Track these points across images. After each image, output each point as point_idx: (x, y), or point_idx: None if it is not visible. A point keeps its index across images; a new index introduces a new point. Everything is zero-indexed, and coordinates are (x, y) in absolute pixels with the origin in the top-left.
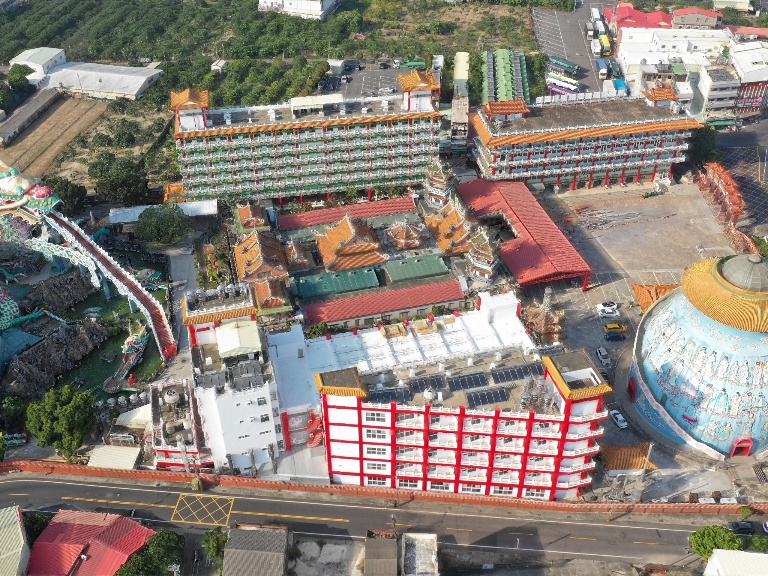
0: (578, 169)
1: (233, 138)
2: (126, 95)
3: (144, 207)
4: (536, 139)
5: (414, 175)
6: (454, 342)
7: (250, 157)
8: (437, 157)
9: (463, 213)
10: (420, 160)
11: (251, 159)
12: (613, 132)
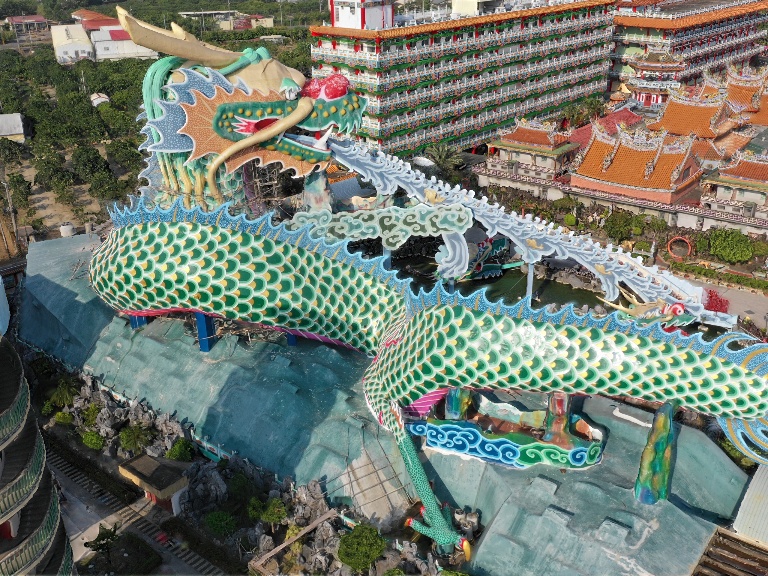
0: (714, 64)
1: (434, 42)
2: (5, 137)
3: (331, 185)
4: (701, 20)
5: (589, 94)
6: None
7: (456, 73)
8: (607, 65)
9: (762, 74)
10: (595, 71)
11: (449, 81)
12: (740, 11)
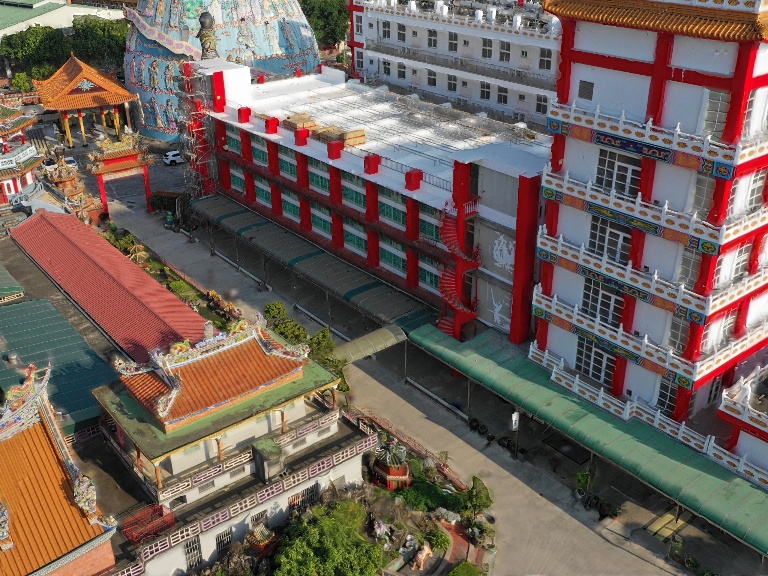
0: None
1: None
2: None
3: None
4: None
5: None
6: (323, 111)
7: None
8: None
9: None
10: None
11: None
12: None
